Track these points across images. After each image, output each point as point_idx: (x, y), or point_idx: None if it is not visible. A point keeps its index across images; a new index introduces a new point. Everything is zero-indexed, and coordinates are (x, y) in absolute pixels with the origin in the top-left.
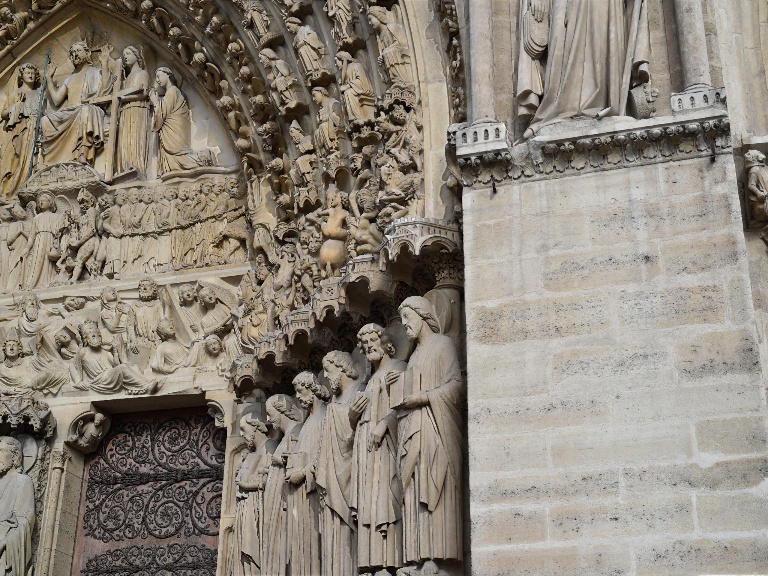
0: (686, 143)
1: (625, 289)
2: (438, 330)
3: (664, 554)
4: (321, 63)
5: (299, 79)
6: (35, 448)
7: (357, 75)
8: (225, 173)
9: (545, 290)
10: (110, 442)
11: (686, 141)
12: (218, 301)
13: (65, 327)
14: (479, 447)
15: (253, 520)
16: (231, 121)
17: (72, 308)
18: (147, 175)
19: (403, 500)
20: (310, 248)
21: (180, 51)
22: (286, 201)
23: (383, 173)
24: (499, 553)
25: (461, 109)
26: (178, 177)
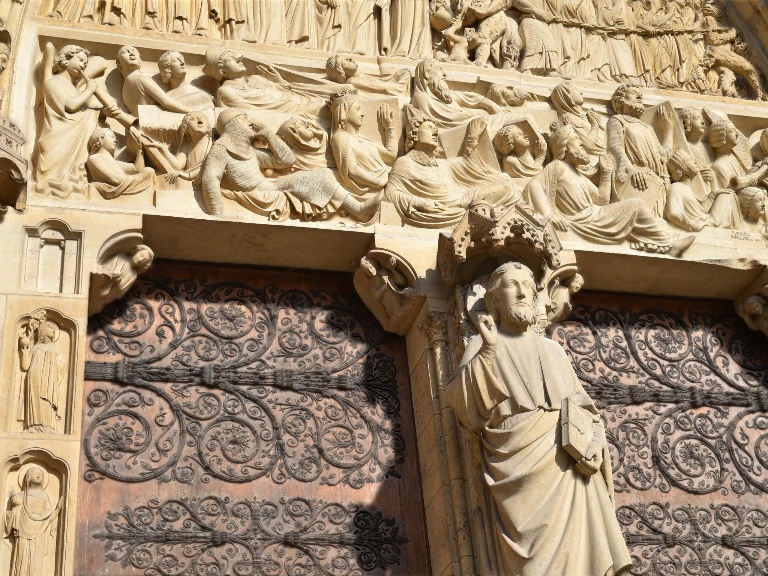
0: None
1: None
2: None
3: None
4: None
5: None
6: None
7: None
8: None
9: None
10: (554, 331)
11: None
12: None
13: (521, 122)
14: None
15: None
16: None
17: (504, 101)
18: None
19: None
20: None
21: None
22: None
23: None
24: None
25: None
26: None
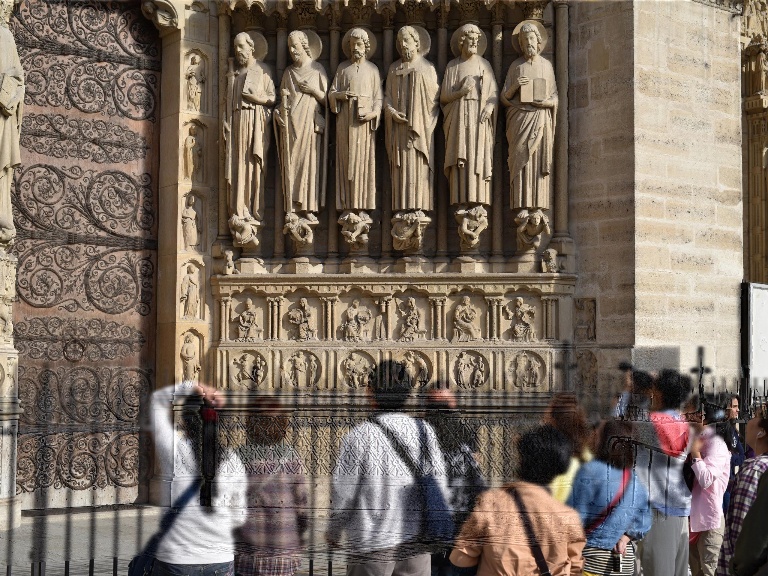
0: (727, 1)
1: None
2: None
3: (705, 234)
4: None
5: None
6: None
7: None
8: None
9: (668, 68)
10: (23, 2)
11: None
12: None
13: None
14: (639, 158)
15: None
16: None
17: None
18: None
19: (525, 166)
20: None
21: None
22: None
23: None
24: (646, 222)
25: None
26: None
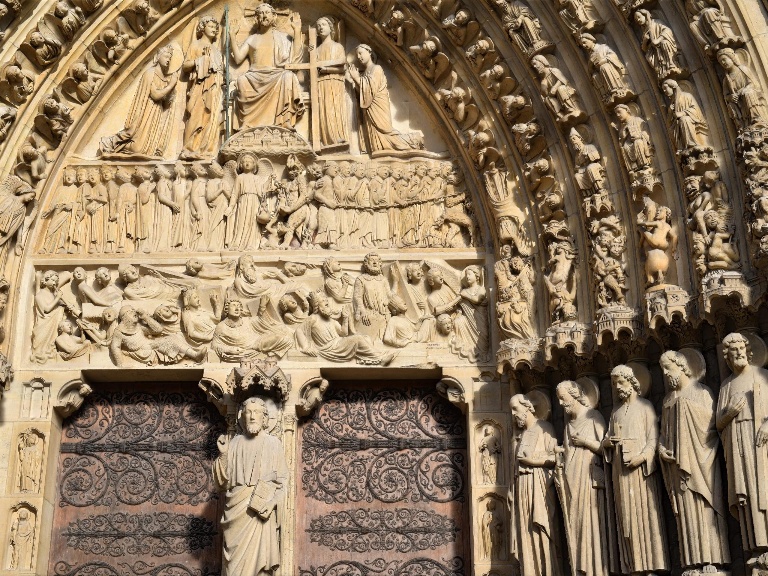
0: None
1: None
2: None
3: None
4: (623, 82)
5: (577, 90)
6: (276, 410)
7: (692, 105)
8: (435, 158)
9: None
10: (322, 407)
11: None
12: None
13: (293, 293)
14: None
15: (541, 494)
16: (460, 112)
17: (292, 274)
18: (350, 149)
19: None
20: (614, 252)
21: (399, 34)
22: (557, 201)
23: (765, 204)
24: None
25: None
26: (390, 156)
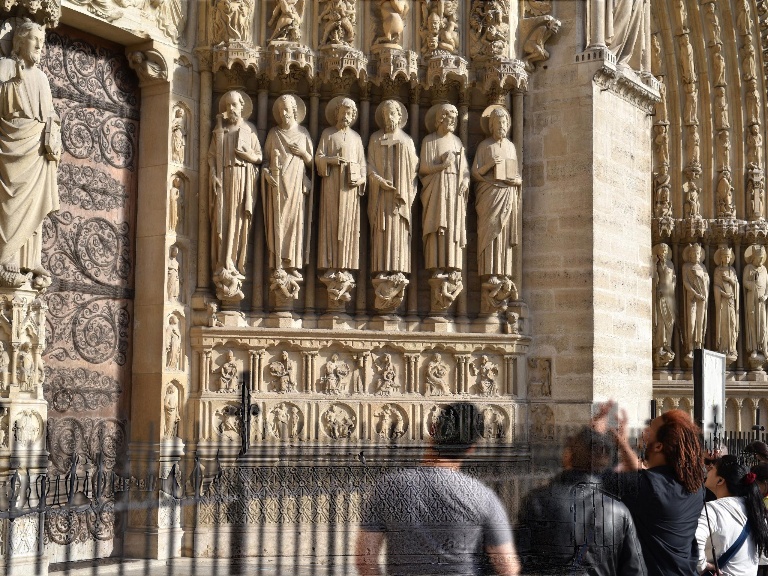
0: None
1: None
2: None
3: None
4: None
5: None
6: None
7: None
8: None
9: None
10: None
11: (645, 101)
12: None
13: None
14: None
15: None
16: None
17: None
18: None
19: (497, 237)
20: None
21: None
22: None
23: (501, 16)
24: None
25: (550, 6)
26: None
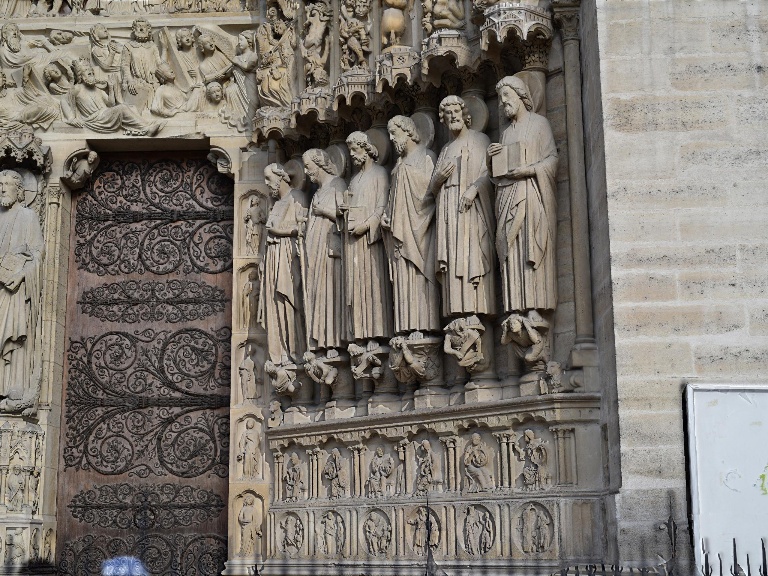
0: None
1: (741, 94)
2: (531, 109)
3: None
4: None
5: None
6: (35, 183)
7: None
8: None
9: (673, 88)
10: (97, 179)
11: None
12: (215, 48)
13: (56, 62)
14: (618, 220)
15: (287, 263)
16: None
17: (58, 42)
18: None
19: (506, 258)
20: (358, 12)
21: None
22: None
23: None
24: (637, 309)
25: None
26: None
